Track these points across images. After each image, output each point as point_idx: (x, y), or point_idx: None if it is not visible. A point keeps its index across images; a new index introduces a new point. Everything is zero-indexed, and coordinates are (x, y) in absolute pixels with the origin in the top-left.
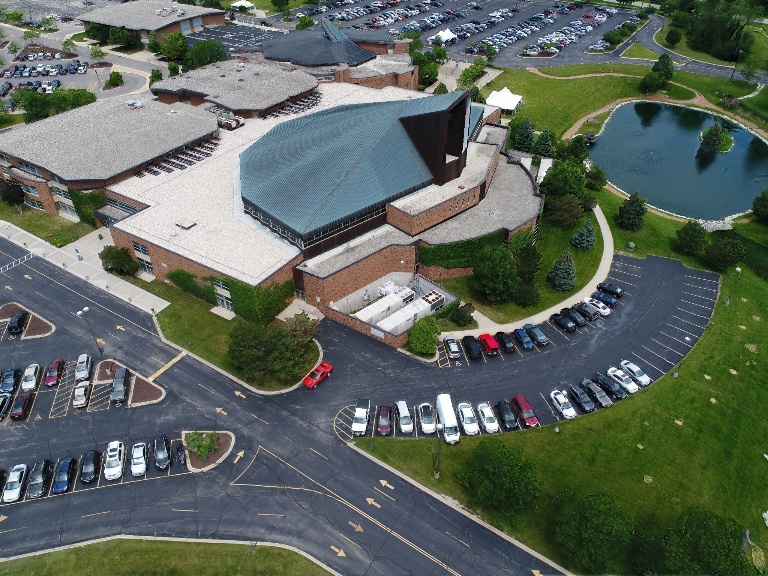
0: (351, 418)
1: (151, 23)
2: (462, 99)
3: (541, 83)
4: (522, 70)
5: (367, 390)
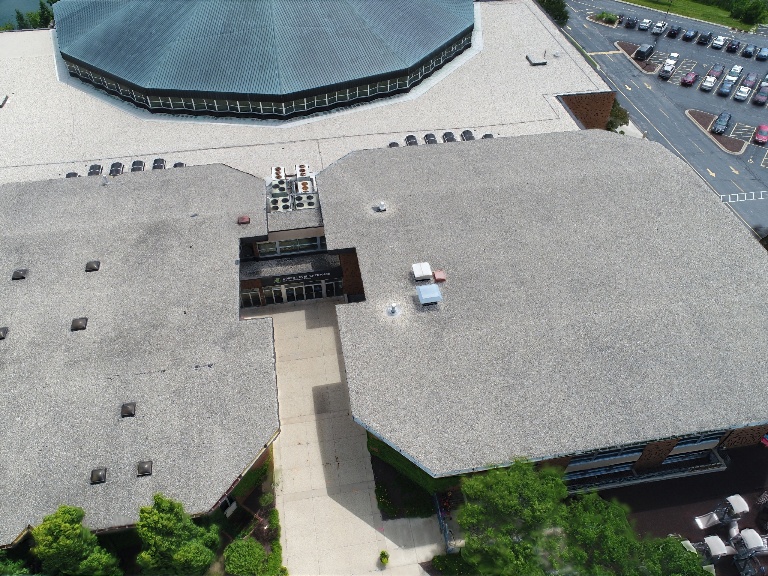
0: None
1: None
2: None
3: None
4: None
5: None
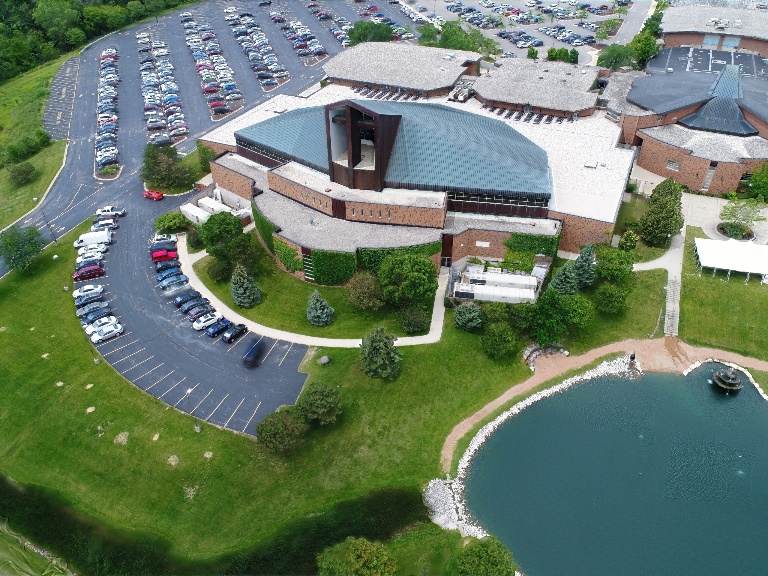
0: None
1: (680, 26)
2: (342, 106)
3: None
4: None
5: (137, 214)
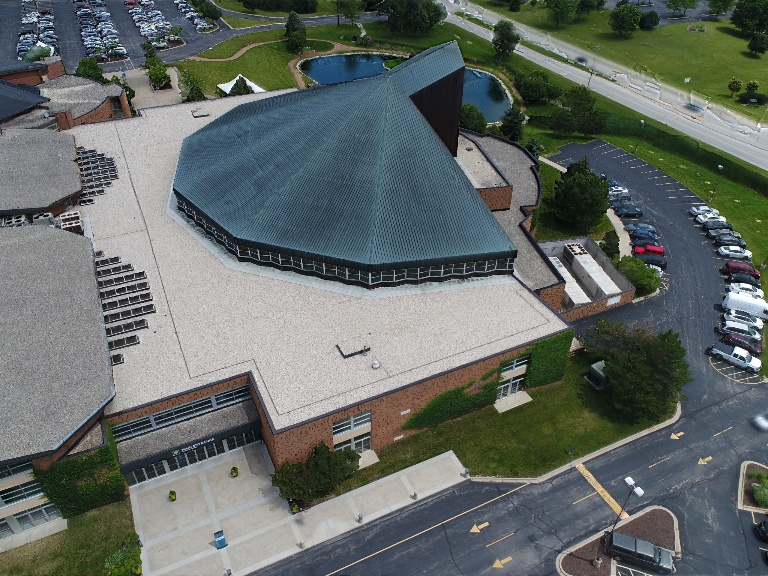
0: (729, 366)
1: None
2: None
3: (228, 67)
4: (189, 61)
5: (689, 342)
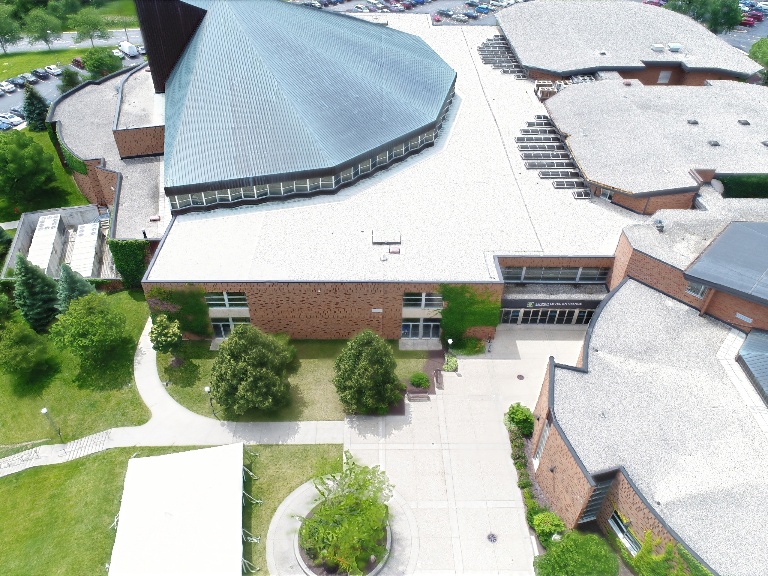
0: None
1: None
2: None
3: None
4: None
5: None
